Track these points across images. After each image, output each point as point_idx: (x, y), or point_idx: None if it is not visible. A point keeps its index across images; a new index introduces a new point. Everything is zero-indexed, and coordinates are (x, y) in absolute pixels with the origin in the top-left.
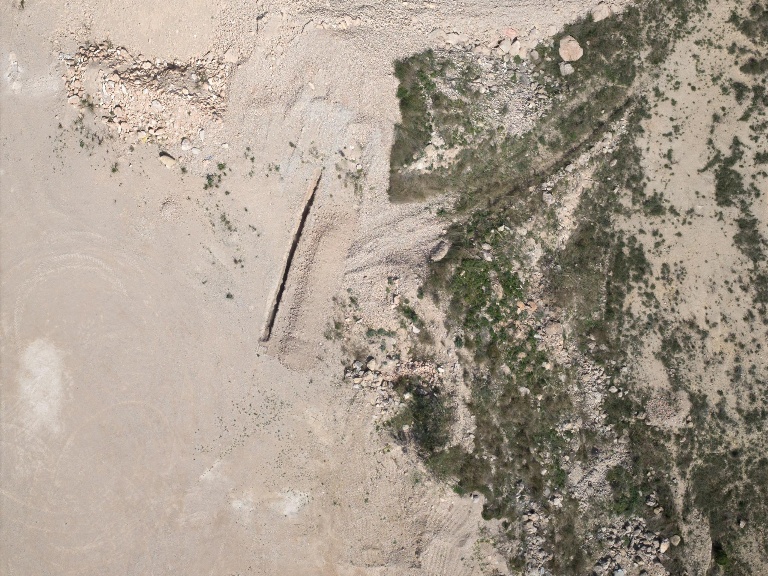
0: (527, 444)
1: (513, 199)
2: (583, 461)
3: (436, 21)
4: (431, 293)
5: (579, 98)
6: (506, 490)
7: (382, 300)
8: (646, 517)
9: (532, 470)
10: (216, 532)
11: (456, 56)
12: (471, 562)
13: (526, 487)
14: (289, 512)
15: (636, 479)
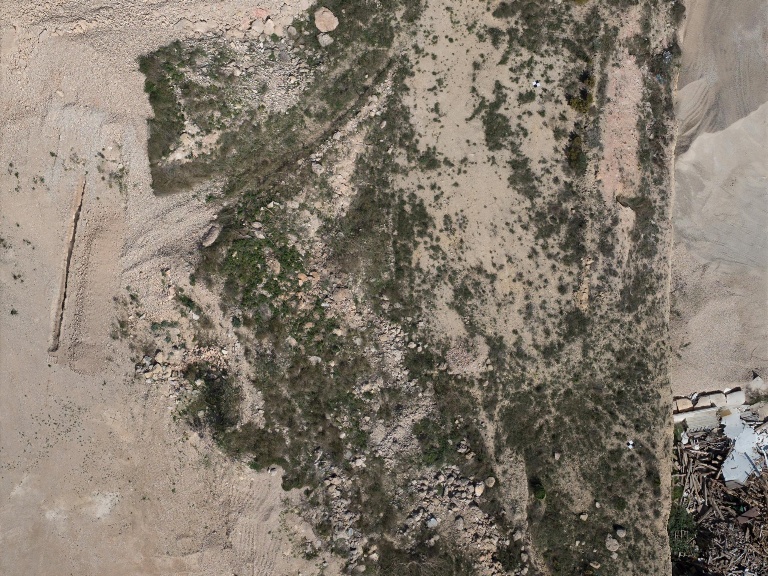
0: (321, 411)
1: (282, 175)
2: (386, 419)
3: (180, 12)
4: (203, 278)
5: (342, 66)
6: (304, 459)
7: (160, 293)
8: (459, 464)
9: (330, 435)
10: (34, 545)
11: (207, 43)
12: (278, 534)
13: (325, 453)
14: (102, 514)
15: (445, 429)
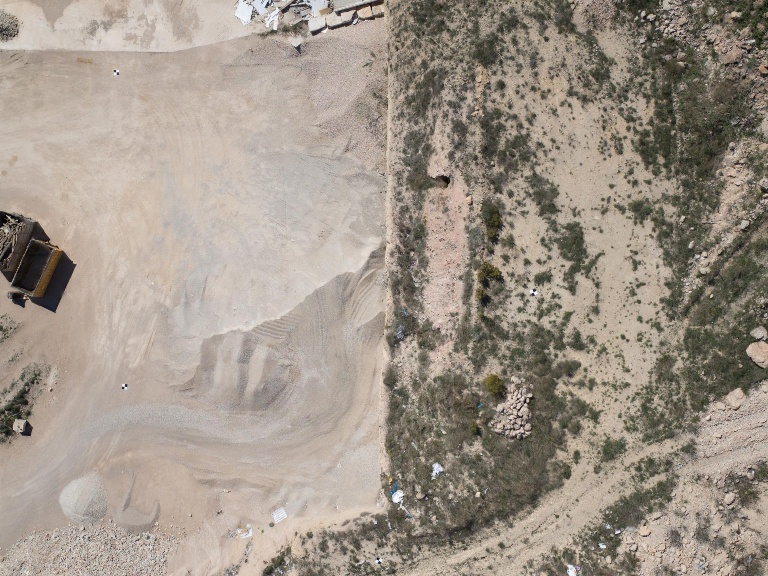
0: None
1: None
2: None
3: None
4: None
5: (740, 306)
6: None
7: None
8: None
9: None
10: None
11: None
12: None
13: None
14: None
15: None
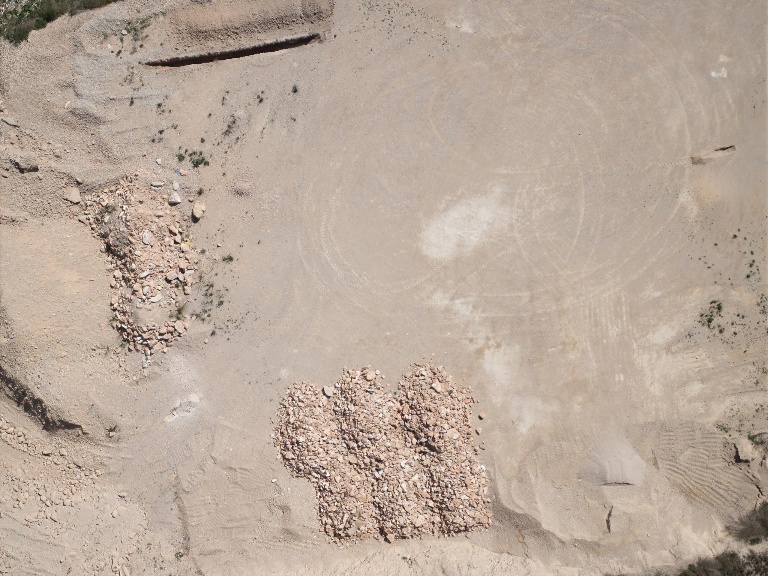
0: None
1: None
2: None
3: None
4: None
5: None
6: None
7: None
8: None
9: None
10: None
11: None
12: None
13: None
14: None
15: None
